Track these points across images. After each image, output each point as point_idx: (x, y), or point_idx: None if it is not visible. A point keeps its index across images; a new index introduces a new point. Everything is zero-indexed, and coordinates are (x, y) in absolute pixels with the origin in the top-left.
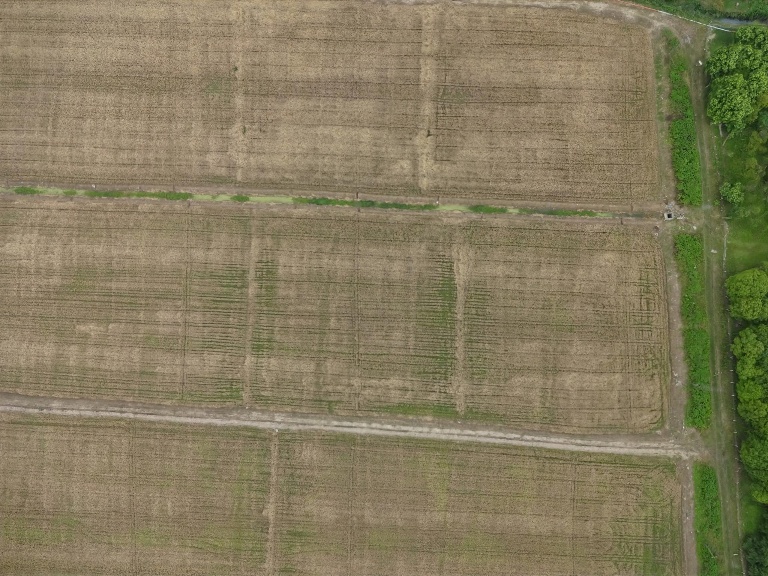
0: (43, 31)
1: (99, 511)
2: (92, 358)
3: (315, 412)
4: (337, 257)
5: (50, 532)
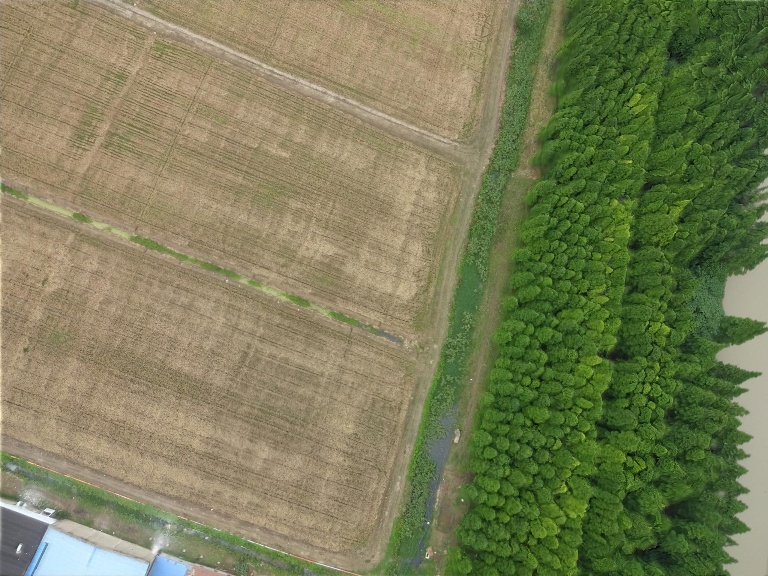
0: (223, 464)
1: (320, 4)
2: (283, 125)
3: (91, 5)
4: (5, 126)
5: (368, 5)
